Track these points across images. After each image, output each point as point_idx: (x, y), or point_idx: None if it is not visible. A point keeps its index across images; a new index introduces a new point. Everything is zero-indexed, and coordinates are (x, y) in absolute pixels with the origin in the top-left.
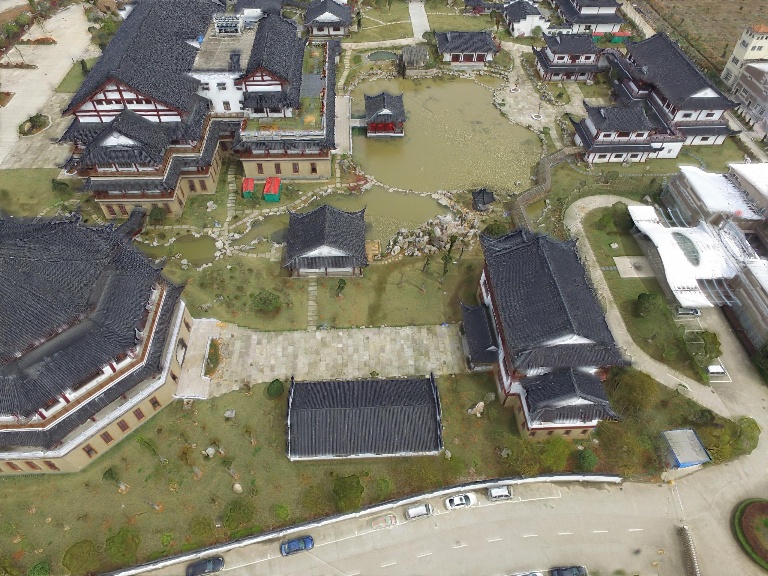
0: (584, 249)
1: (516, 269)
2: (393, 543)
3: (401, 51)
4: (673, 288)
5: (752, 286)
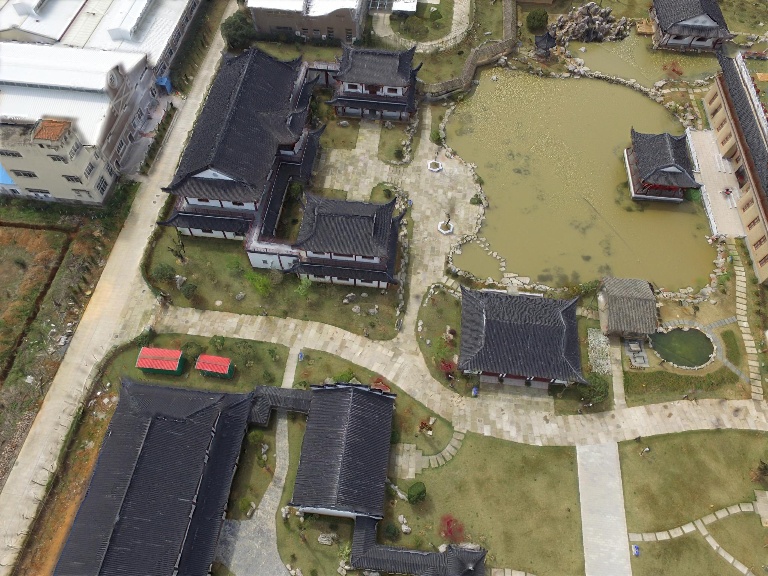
0: (460, 12)
1: None
2: None
3: (647, 364)
4: None
5: None
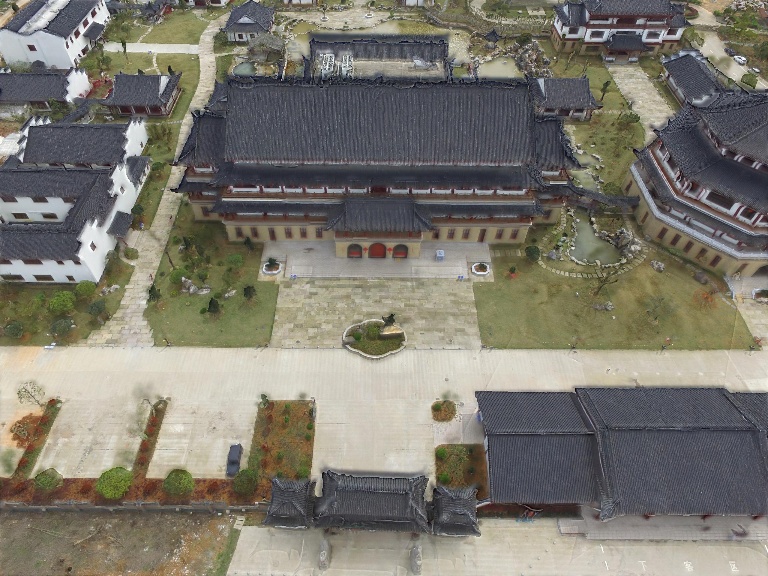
0: None
1: (615, 2)
2: (747, 90)
3: (236, 60)
4: None
5: None
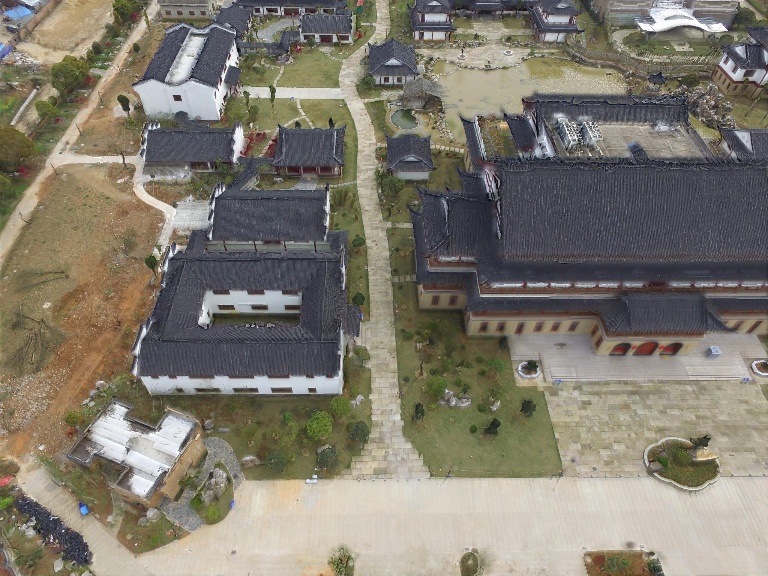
0: None
1: None
2: None
3: (389, 107)
4: (713, 31)
5: (704, 8)
